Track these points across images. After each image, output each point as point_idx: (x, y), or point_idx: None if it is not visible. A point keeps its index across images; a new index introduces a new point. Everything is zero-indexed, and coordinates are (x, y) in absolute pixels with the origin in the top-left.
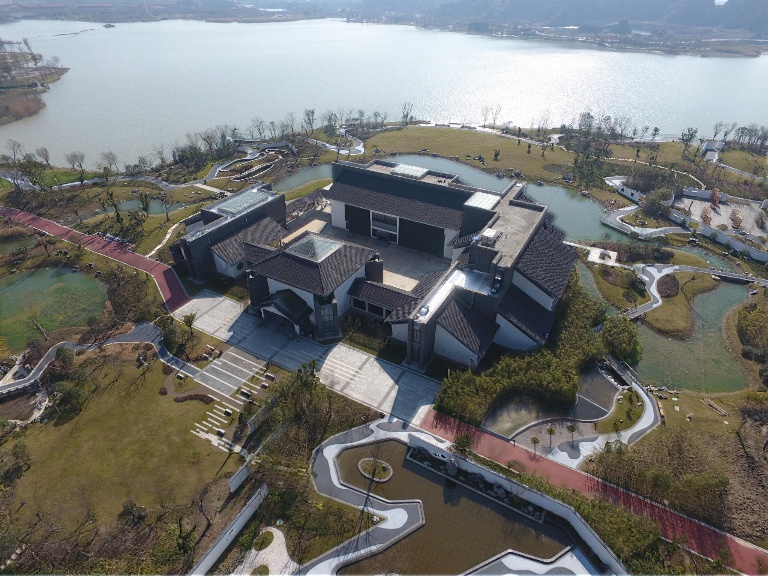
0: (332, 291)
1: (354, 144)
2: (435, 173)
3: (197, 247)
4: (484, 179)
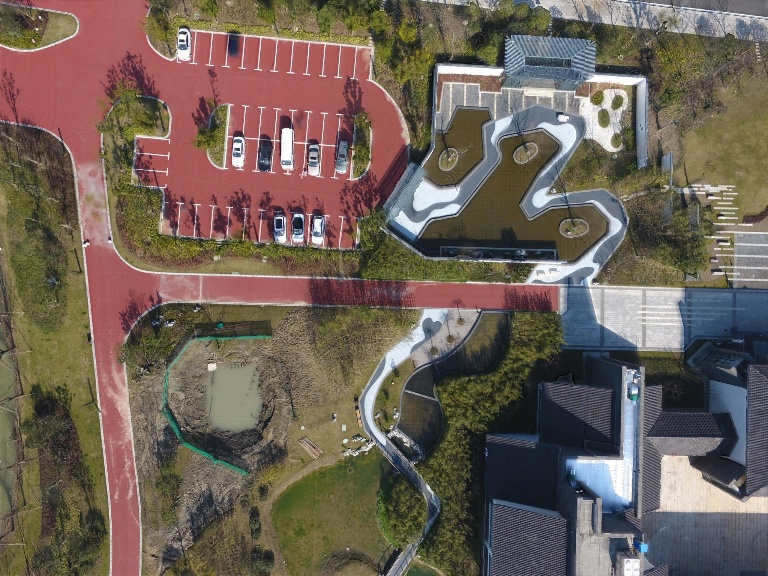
0: (749, 379)
1: None
2: None
3: None
4: None
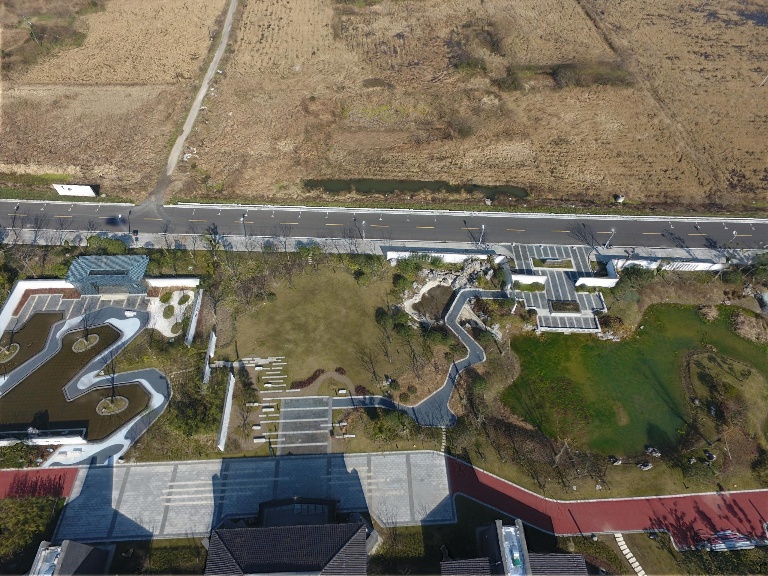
0: None
1: None
2: None
3: None
4: None
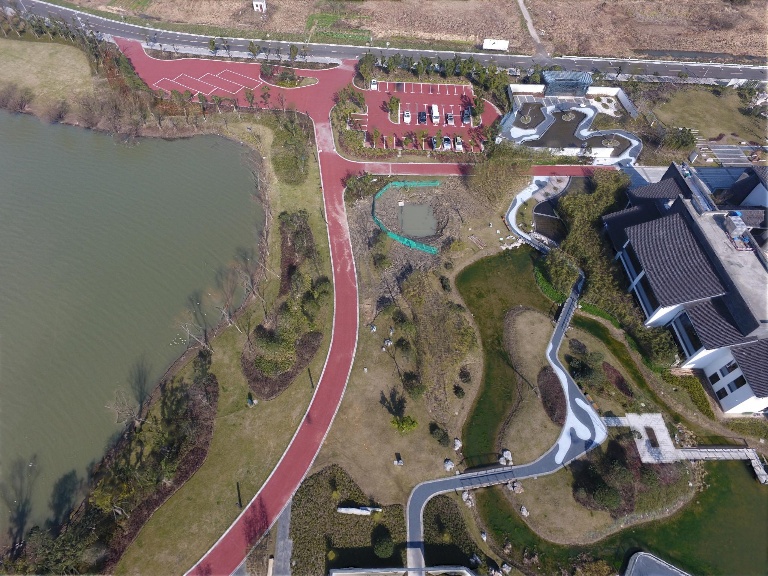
0: (756, 172)
1: None
2: None
3: None
4: None
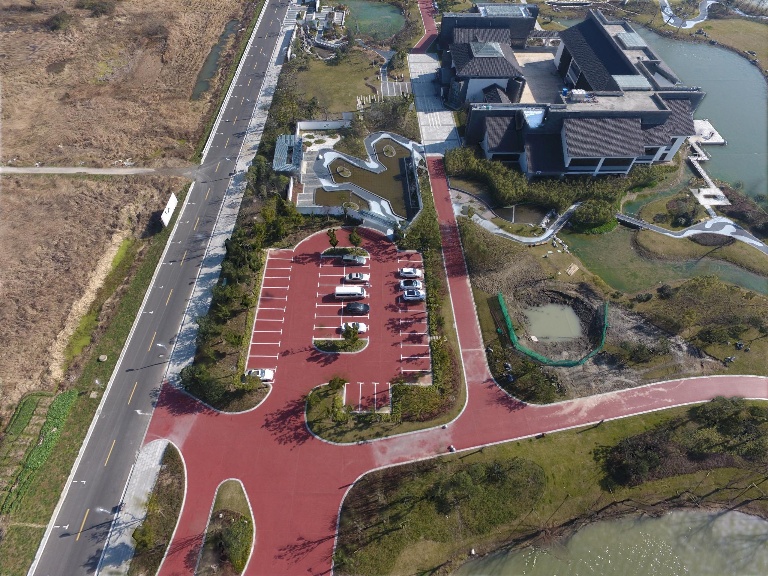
0: (465, 76)
1: (693, 18)
2: (649, 51)
3: (447, 23)
4: (756, 103)
